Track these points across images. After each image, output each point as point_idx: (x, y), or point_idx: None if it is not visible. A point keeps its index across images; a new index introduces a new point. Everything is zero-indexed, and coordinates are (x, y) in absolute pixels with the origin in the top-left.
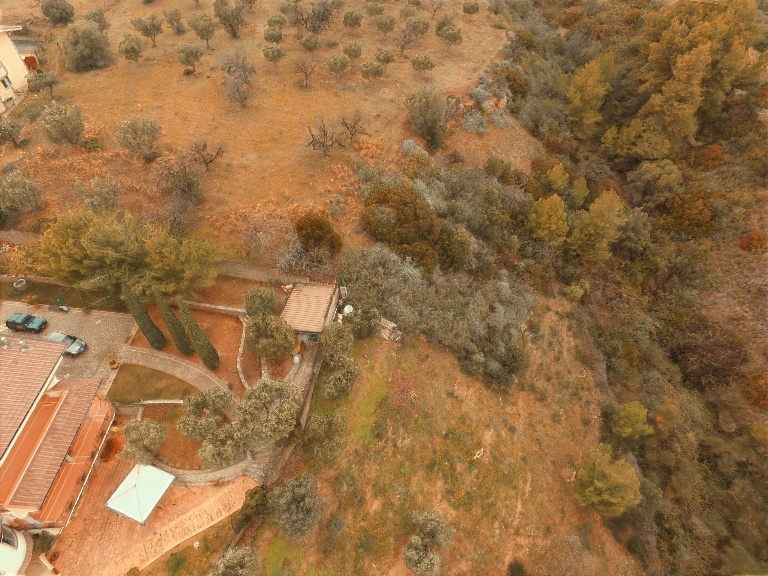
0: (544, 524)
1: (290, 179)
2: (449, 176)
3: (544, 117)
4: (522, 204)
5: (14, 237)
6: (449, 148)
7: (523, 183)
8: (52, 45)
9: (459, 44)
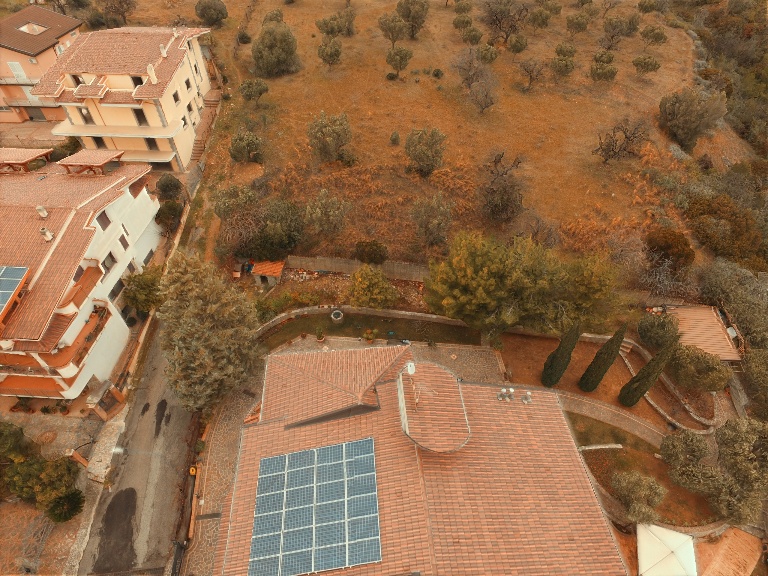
0: None
1: (588, 190)
2: (716, 182)
3: (753, 118)
4: None
5: (316, 263)
6: None
7: (761, 187)
8: (220, 49)
9: (661, 44)
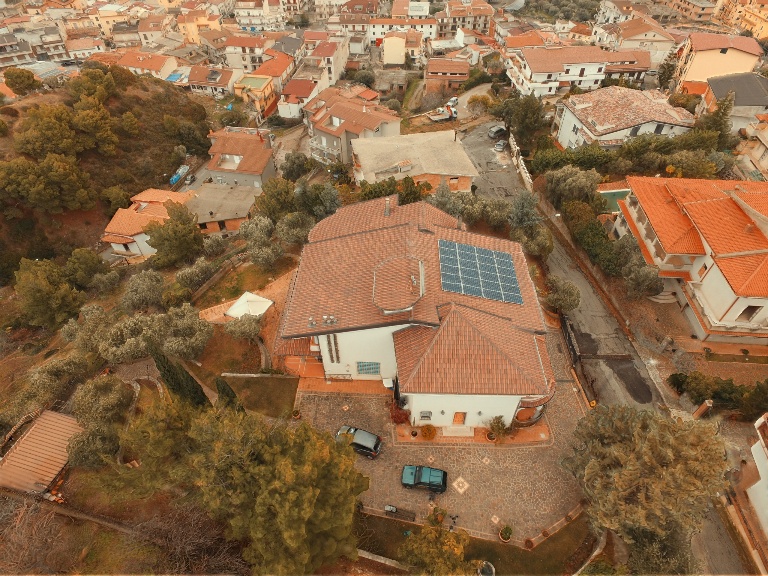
0: None
1: None
2: None
3: None
4: None
5: None
6: None
7: None
8: None
9: None
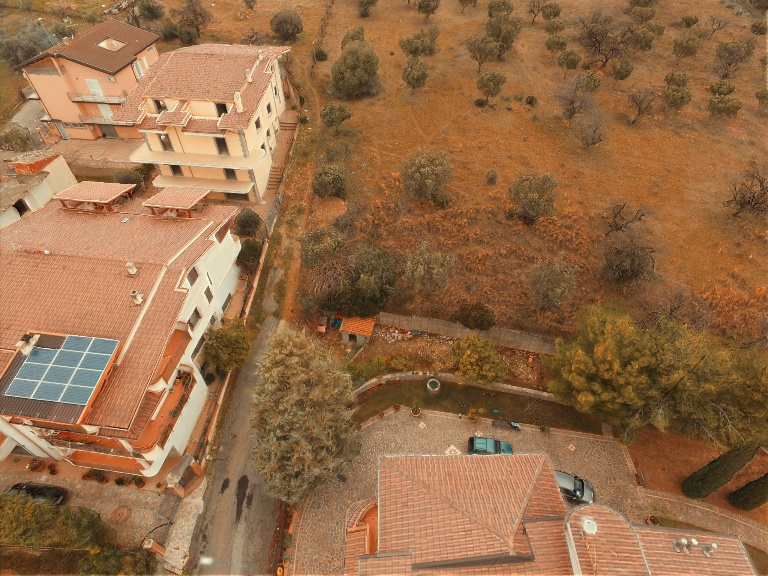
0: None
1: (720, 250)
2: None
3: None
4: None
5: (411, 323)
6: None
7: None
8: (295, 66)
9: None
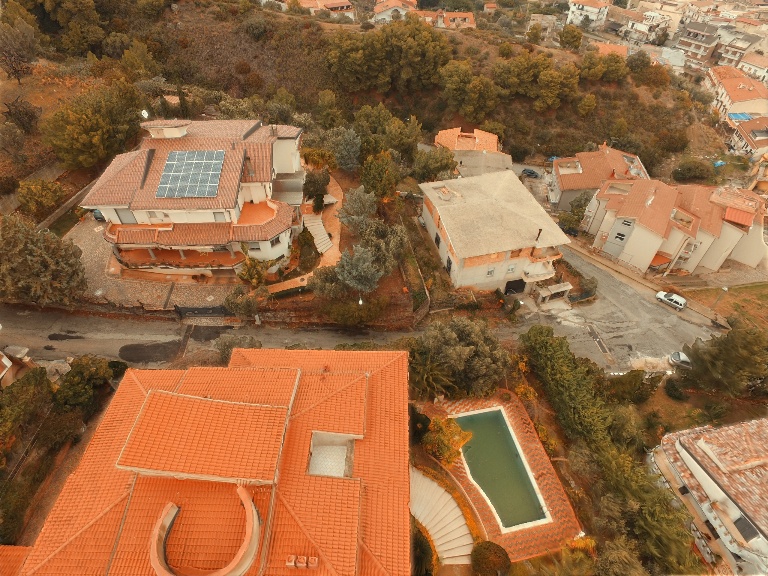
0: None
1: None
2: None
3: None
4: None
5: None
6: None
7: None
8: None
9: None
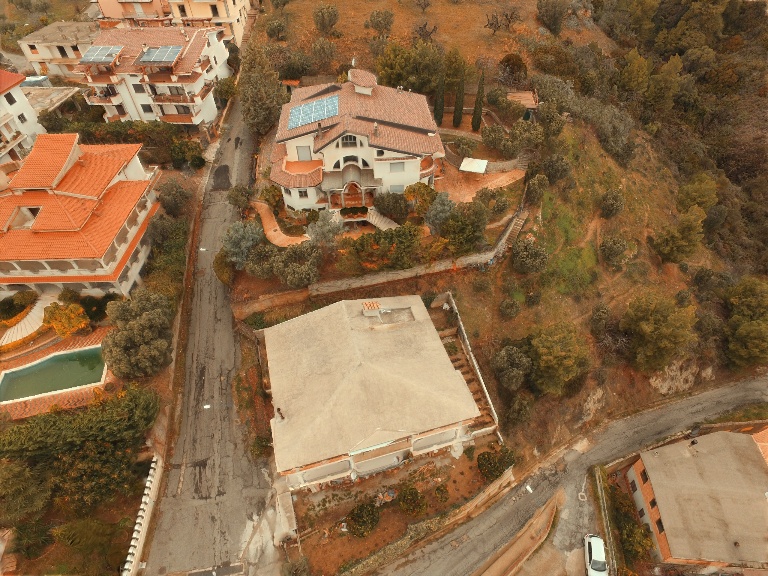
0: (661, 225)
1: (478, 46)
2: (569, 51)
3: (616, 23)
4: (614, 72)
5: (318, 81)
6: (561, 38)
7: None
8: None
9: None
